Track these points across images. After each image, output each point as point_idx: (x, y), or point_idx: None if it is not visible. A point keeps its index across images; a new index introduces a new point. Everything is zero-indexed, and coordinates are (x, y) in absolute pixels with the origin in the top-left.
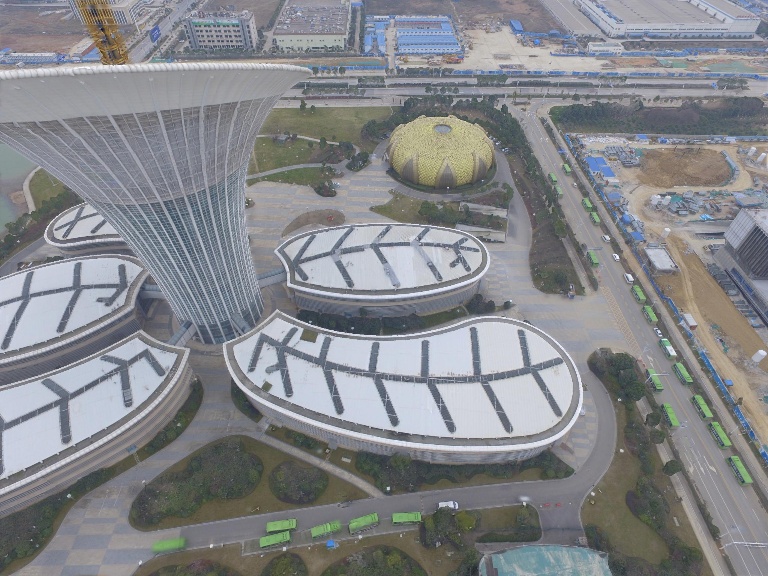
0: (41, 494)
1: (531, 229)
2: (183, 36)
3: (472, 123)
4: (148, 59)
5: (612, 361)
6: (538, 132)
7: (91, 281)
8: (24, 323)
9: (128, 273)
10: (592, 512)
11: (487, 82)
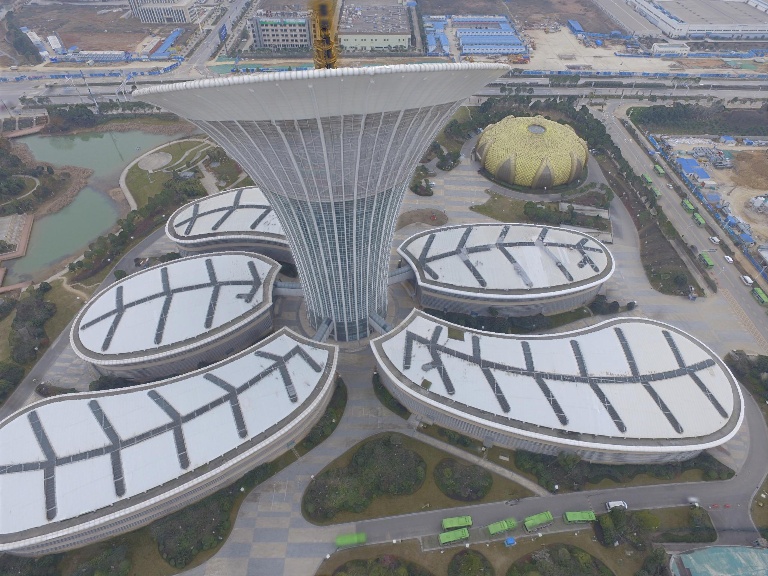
0: (214, 487)
1: (636, 230)
2: (245, 35)
3: None
4: (215, 58)
5: (754, 363)
6: None
7: (226, 277)
8: (172, 318)
9: (259, 270)
10: (763, 514)
11: (559, 82)
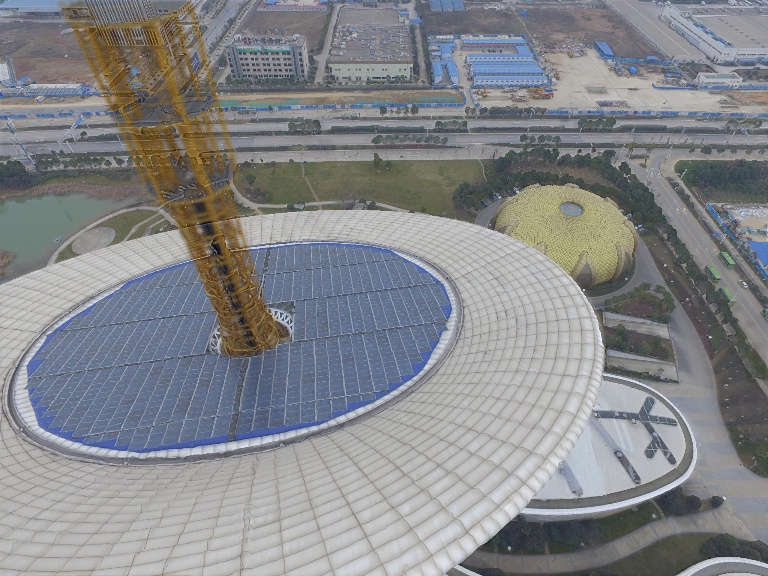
0: None
1: (708, 359)
2: (223, 61)
3: (590, 188)
4: (185, 91)
5: None
6: (671, 199)
7: None
8: None
9: None
10: None
11: (591, 127)
